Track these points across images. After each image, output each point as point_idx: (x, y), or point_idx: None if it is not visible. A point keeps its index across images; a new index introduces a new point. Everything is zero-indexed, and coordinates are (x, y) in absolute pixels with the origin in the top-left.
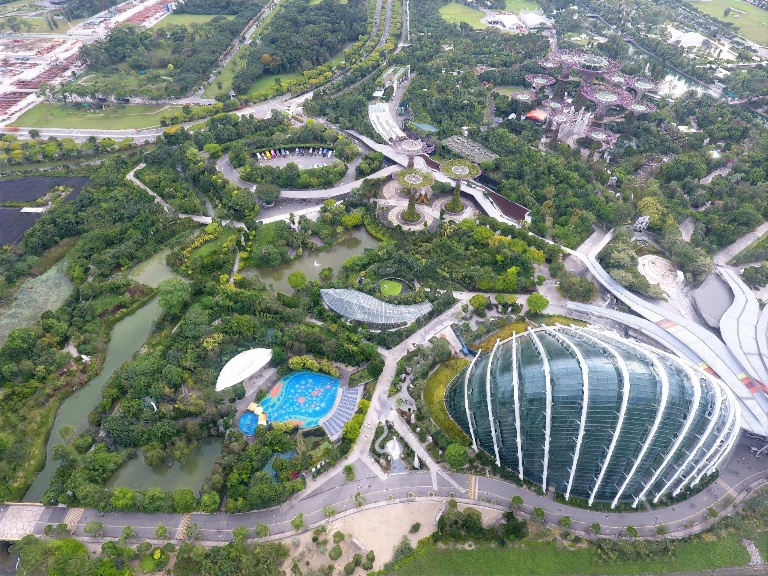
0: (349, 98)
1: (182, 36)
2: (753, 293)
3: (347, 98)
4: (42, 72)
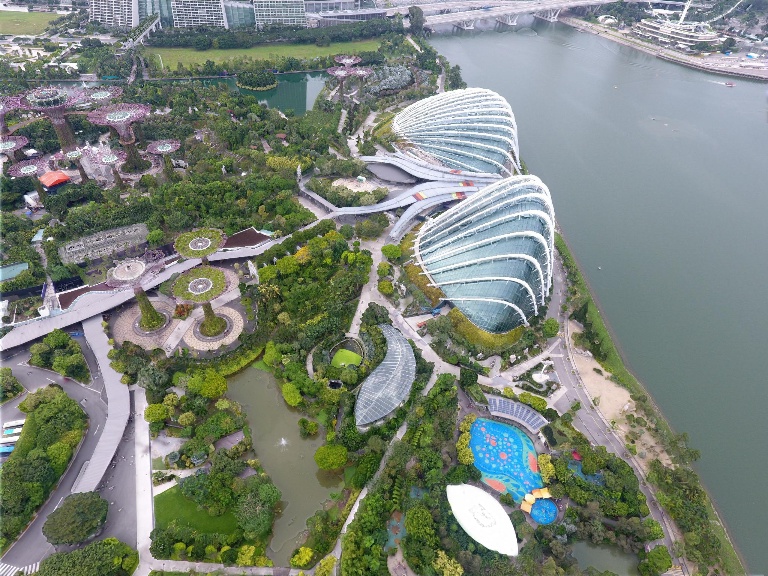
0: None
1: None
2: (388, 157)
3: None
4: None
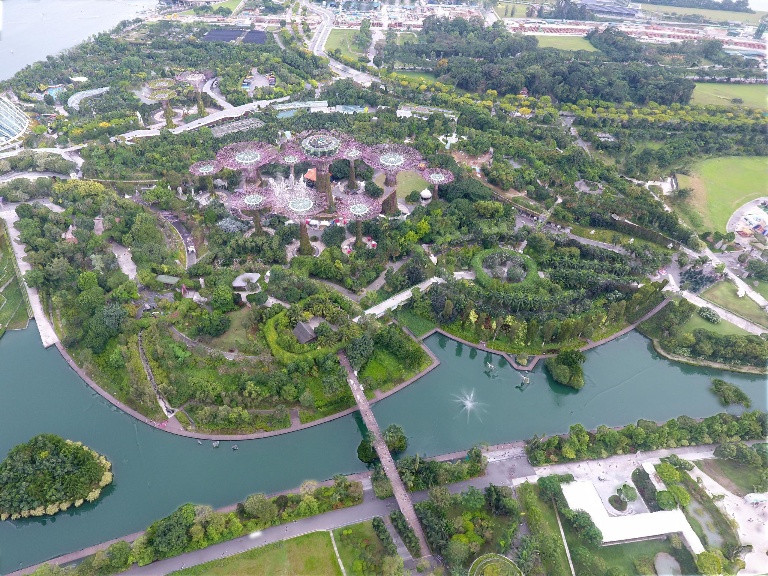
0: (339, 84)
1: (495, 39)
2: None
3: (339, 84)
4: (418, 24)
